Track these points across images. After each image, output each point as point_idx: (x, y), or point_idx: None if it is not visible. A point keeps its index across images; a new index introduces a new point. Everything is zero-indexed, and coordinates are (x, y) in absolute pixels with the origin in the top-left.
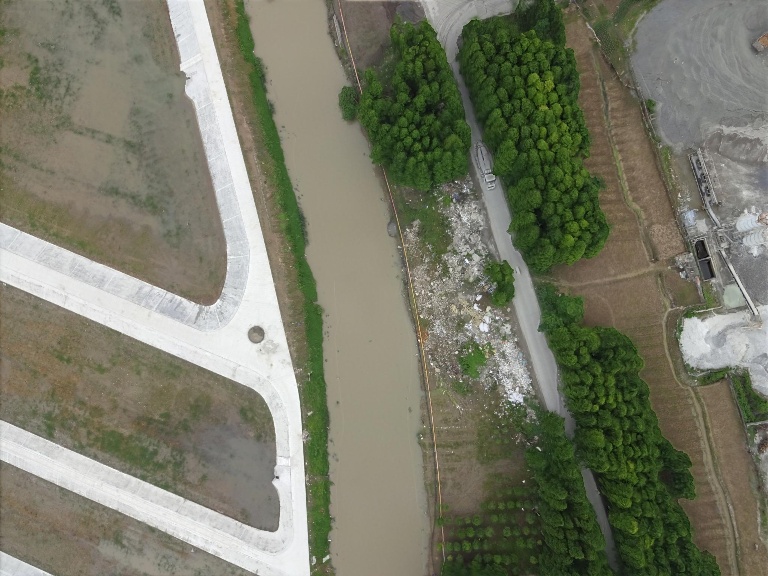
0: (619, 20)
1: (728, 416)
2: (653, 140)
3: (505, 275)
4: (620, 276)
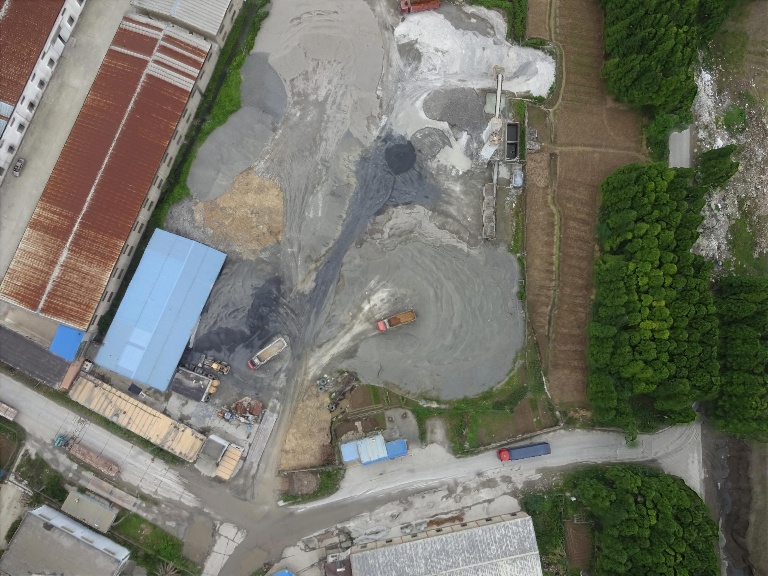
0: (522, 389)
1: (533, 8)
2: (524, 262)
3: (731, 163)
4: (589, 150)
